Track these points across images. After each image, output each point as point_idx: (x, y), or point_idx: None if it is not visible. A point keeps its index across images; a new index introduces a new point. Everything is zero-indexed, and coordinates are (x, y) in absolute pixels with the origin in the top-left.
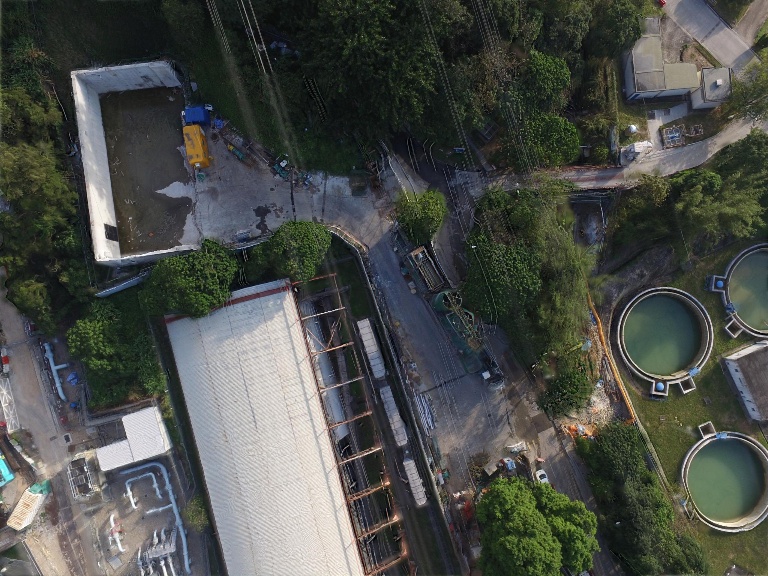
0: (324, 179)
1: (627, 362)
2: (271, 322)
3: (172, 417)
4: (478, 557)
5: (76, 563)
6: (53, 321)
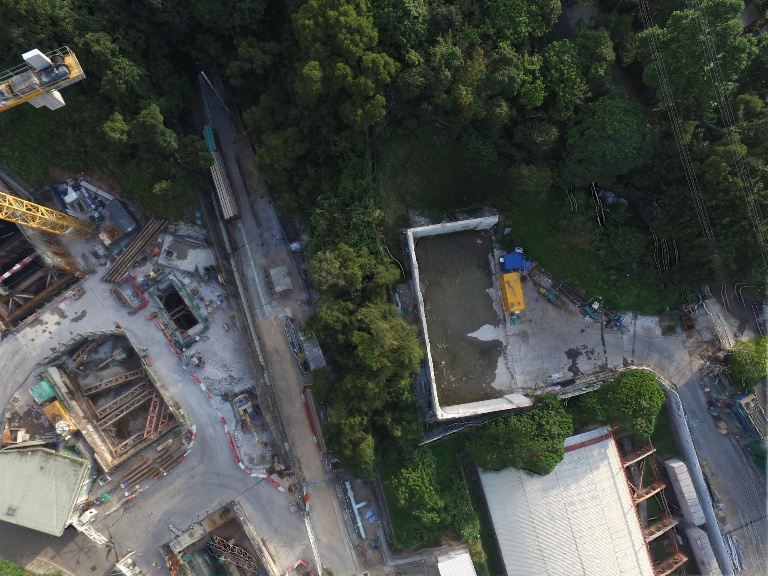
0: (634, 319)
1: None
2: (597, 472)
3: (484, 562)
4: None
5: None
6: None
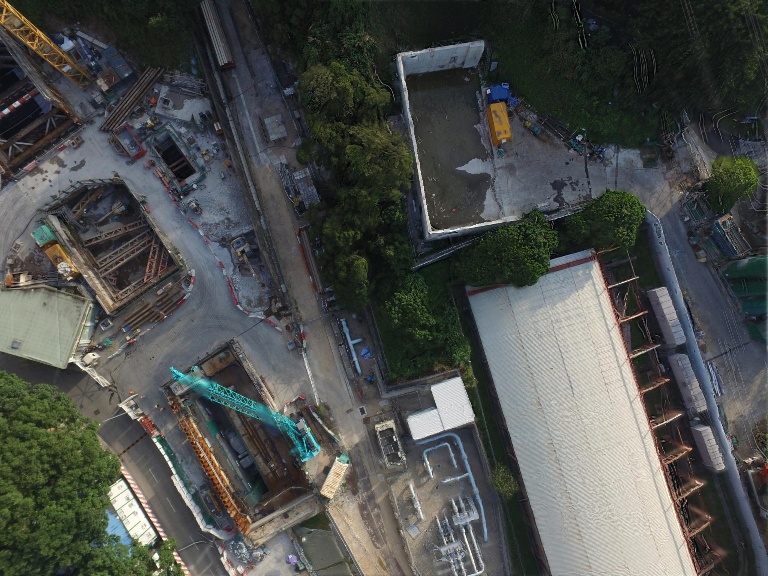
0: (616, 152)
1: None
2: (582, 291)
3: (475, 387)
4: None
5: (377, 532)
6: (366, 295)
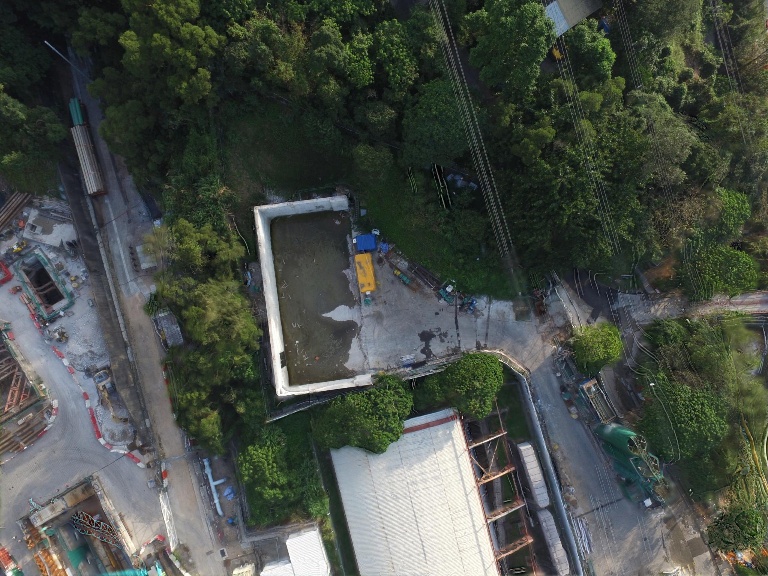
0: (488, 303)
1: None
2: (441, 452)
3: (333, 540)
4: None
5: None
6: (222, 445)
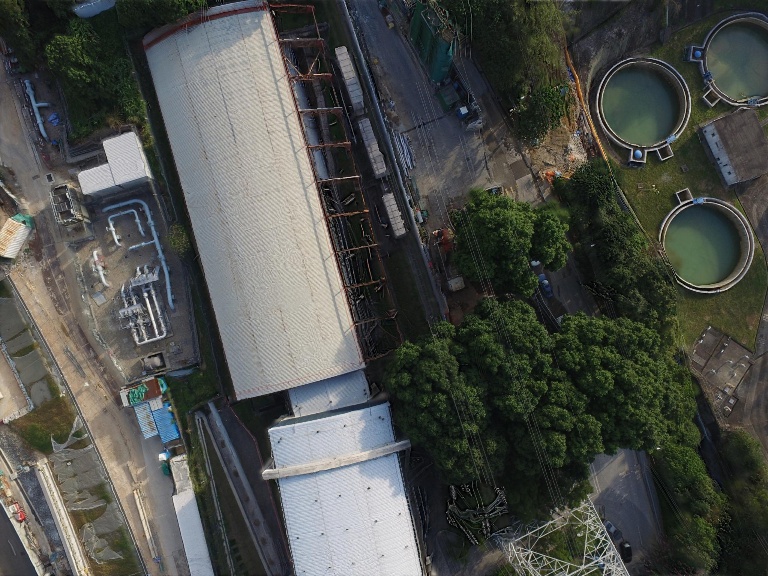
0: None
1: (606, 130)
2: (249, 39)
3: (153, 145)
4: (457, 294)
5: (60, 298)
6: (32, 42)
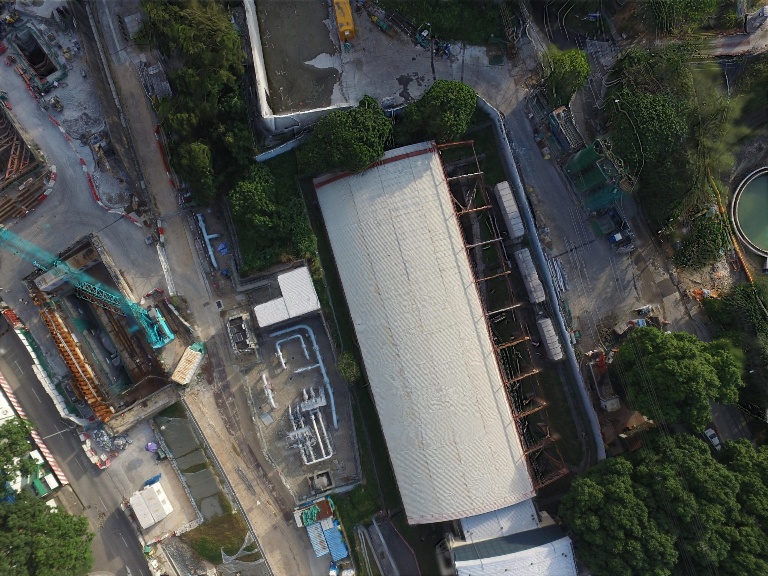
0: (462, 48)
1: (741, 238)
2: (420, 180)
3: (322, 278)
4: (610, 413)
5: (231, 419)
6: (213, 185)
